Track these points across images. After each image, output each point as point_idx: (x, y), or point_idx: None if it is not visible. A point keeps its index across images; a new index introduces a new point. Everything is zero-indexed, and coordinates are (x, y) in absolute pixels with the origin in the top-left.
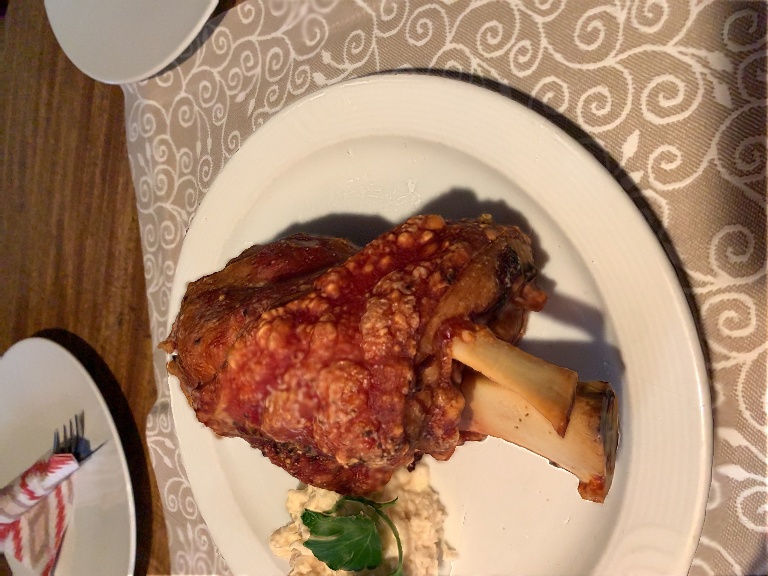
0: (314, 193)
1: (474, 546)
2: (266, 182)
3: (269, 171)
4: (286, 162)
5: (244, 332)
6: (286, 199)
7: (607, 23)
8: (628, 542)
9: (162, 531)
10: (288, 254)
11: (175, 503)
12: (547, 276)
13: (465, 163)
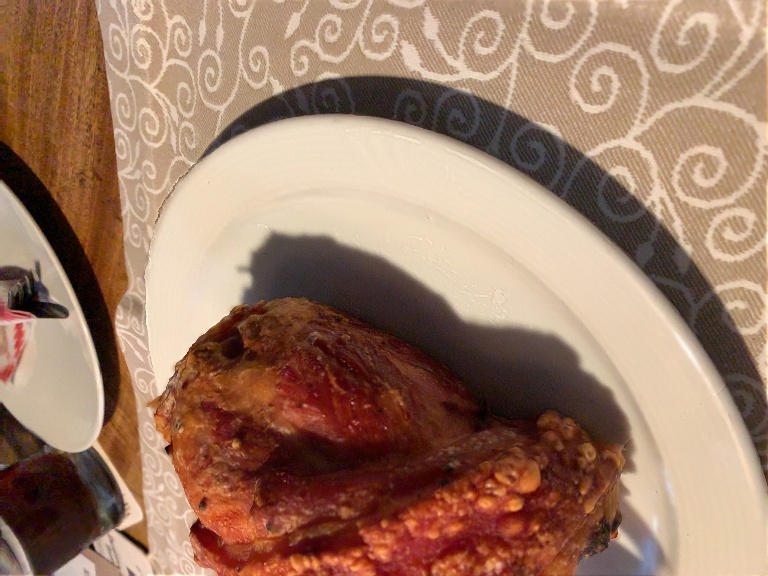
0: (364, 221)
1: None
2: (301, 185)
3: (309, 178)
4: (336, 181)
5: (266, 569)
6: (324, 211)
7: None
8: None
9: (130, 395)
10: (326, 399)
11: (145, 387)
12: (623, 483)
13: (585, 338)
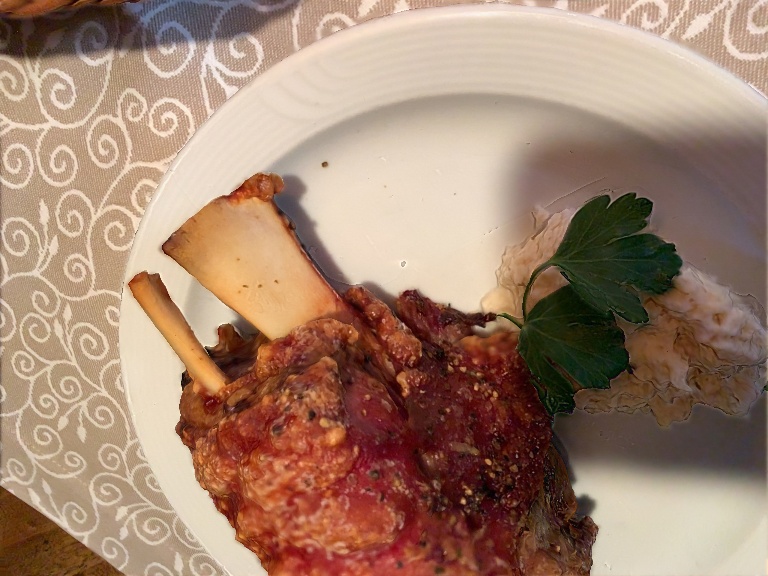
0: None
1: (508, 201)
2: None
3: None
4: None
5: None
6: None
7: (93, 410)
8: (317, 114)
9: None
10: None
11: None
12: None
13: None
